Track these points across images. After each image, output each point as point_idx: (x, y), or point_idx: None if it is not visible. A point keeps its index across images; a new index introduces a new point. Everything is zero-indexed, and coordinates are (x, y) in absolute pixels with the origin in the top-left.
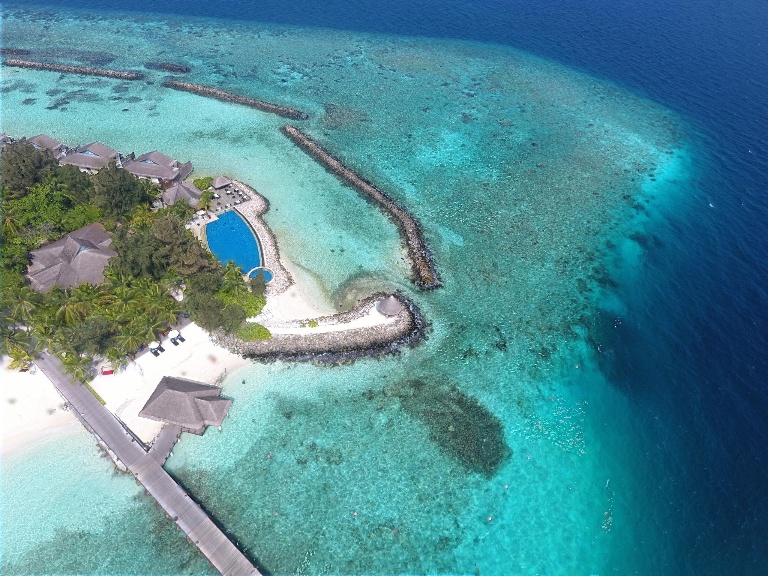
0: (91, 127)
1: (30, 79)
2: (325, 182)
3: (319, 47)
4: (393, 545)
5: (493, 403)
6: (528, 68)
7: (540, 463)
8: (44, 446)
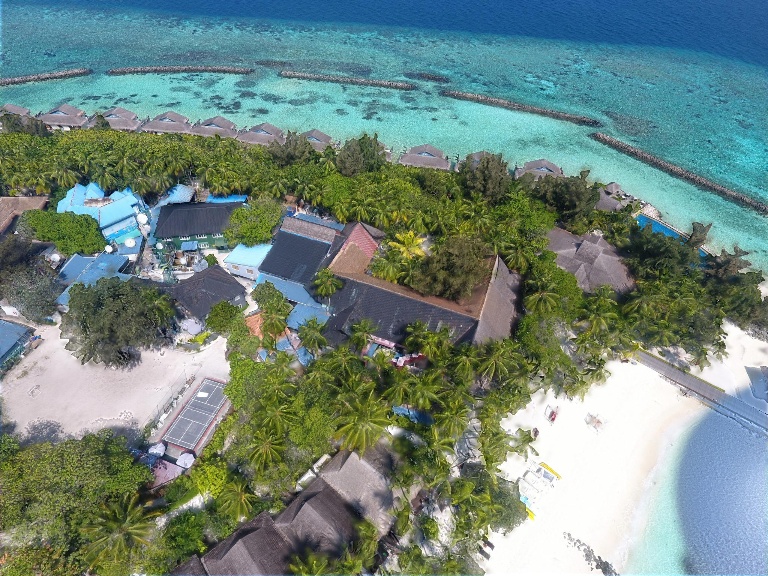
0: (422, 136)
1: (319, 90)
2: (681, 187)
3: (539, 55)
4: None
5: None
6: (748, 74)
7: None
8: (700, 428)
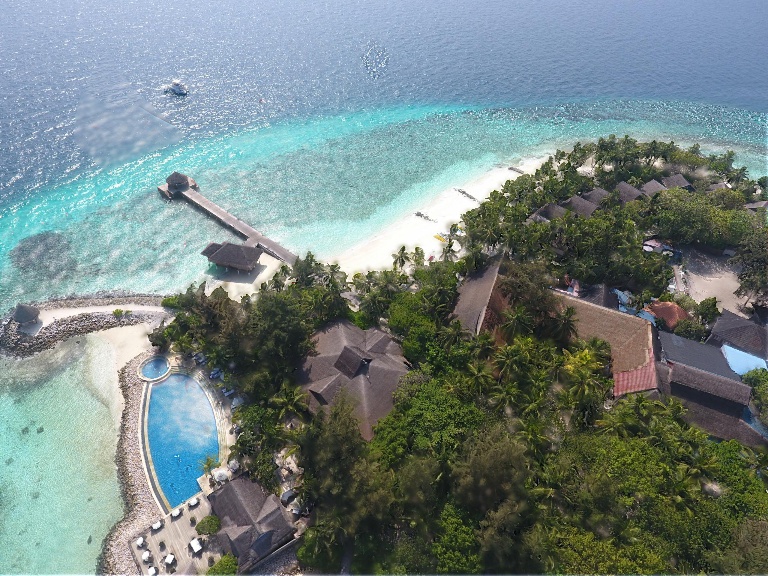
0: None
1: None
2: None
3: None
4: (128, 214)
5: (2, 264)
6: None
7: (8, 231)
8: (325, 256)
